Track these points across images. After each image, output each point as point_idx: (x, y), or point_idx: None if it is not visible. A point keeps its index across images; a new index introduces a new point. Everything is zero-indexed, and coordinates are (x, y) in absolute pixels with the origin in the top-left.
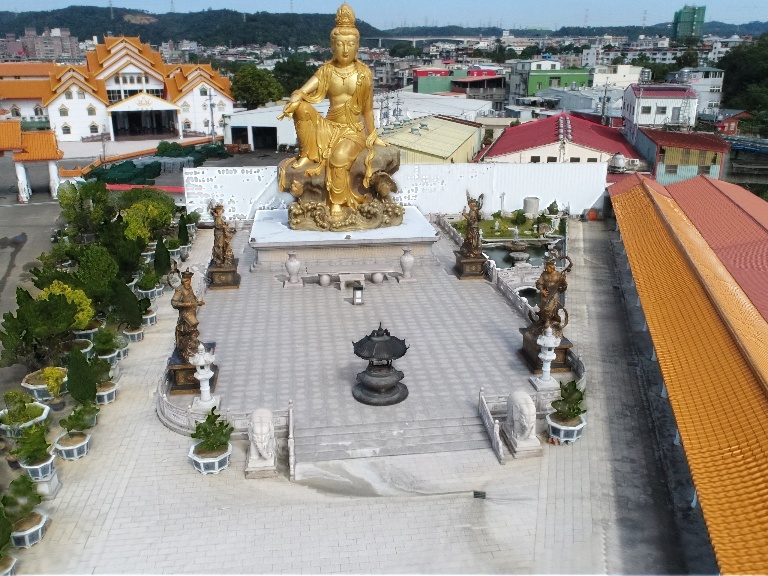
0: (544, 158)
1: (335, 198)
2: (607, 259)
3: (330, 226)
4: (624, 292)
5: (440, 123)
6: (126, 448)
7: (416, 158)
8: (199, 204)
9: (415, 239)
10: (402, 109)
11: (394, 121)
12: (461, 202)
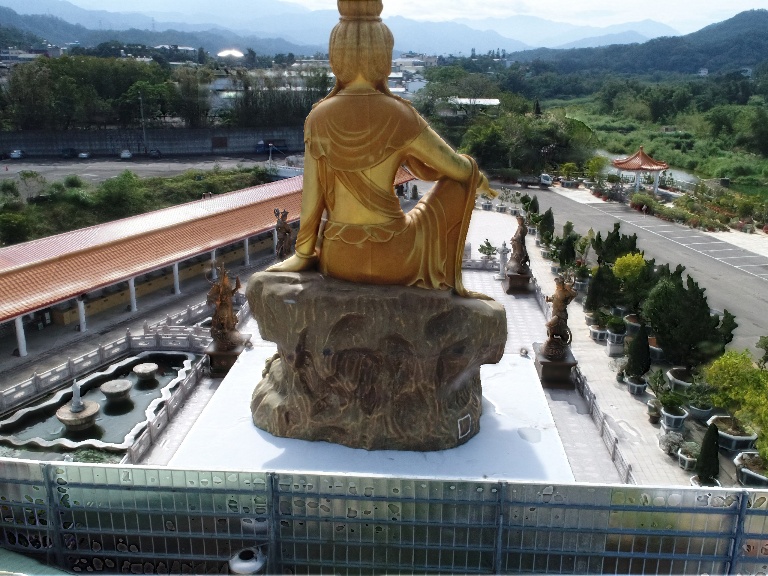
0: None
1: None
2: (1, 378)
3: None
4: (113, 325)
5: None
6: (534, 272)
7: None
8: None
9: None
10: None
11: None
12: None
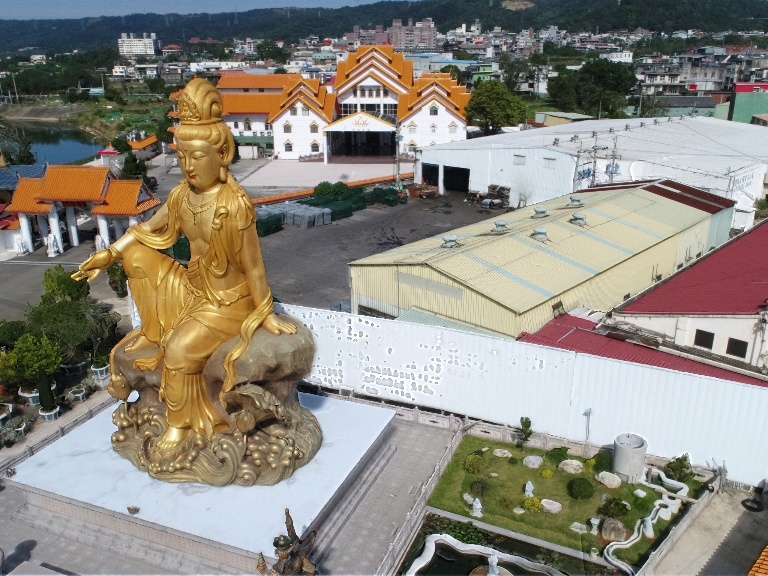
0: (721, 338)
1: (171, 415)
2: None
3: (148, 465)
4: None
5: (637, 204)
6: None
7: (476, 302)
8: None
9: (236, 549)
10: (620, 164)
11: (604, 181)
12: (513, 405)
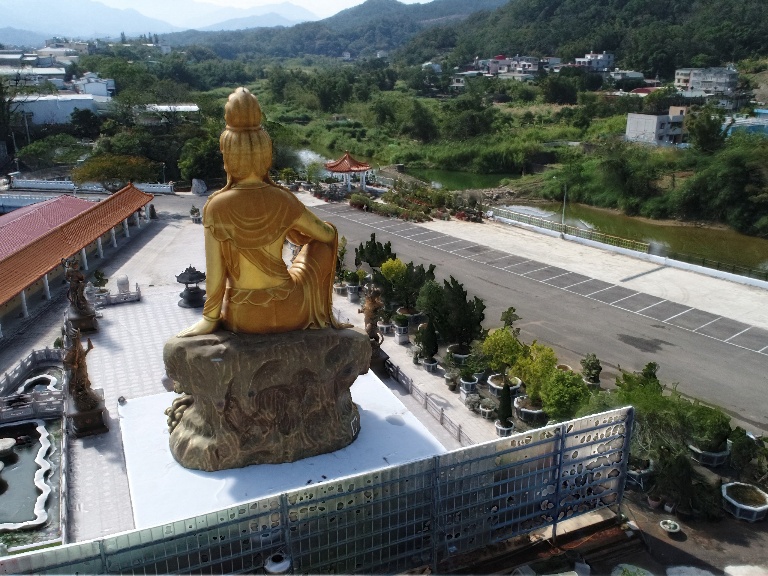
0: None
1: None
2: None
3: None
4: None
5: None
6: None
7: None
8: (603, 477)
9: None
10: None
11: None
12: None
